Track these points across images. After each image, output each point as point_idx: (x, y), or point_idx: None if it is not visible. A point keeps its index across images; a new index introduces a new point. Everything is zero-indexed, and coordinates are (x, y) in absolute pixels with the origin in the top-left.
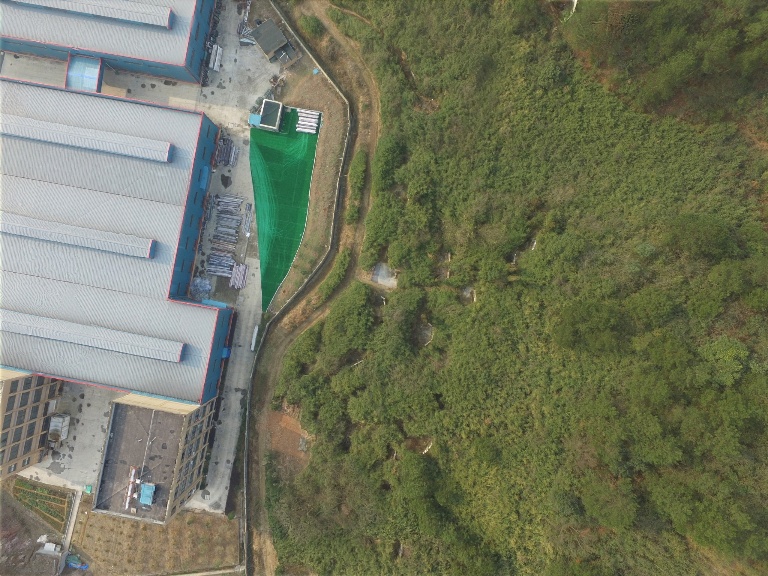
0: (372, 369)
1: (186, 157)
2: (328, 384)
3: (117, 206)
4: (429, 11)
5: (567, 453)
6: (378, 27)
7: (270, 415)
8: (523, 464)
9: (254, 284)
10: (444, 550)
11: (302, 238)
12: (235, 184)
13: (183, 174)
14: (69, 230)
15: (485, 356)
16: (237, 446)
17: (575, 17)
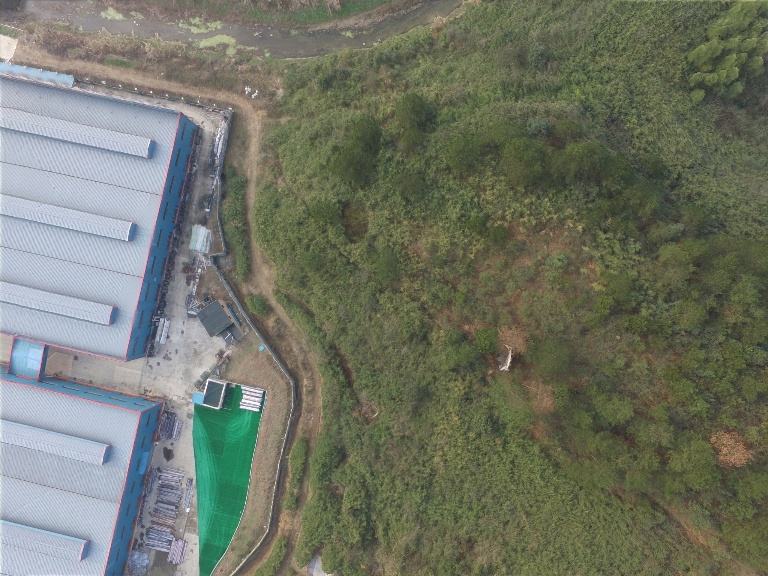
0: None
1: (122, 457)
2: None
3: (53, 500)
4: (369, 326)
5: None
6: (321, 326)
7: None
8: None
9: (192, 560)
10: None
11: (241, 517)
12: (177, 458)
13: (119, 473)
14: (3, 530)
15: None
16: None
17: (508, 375)
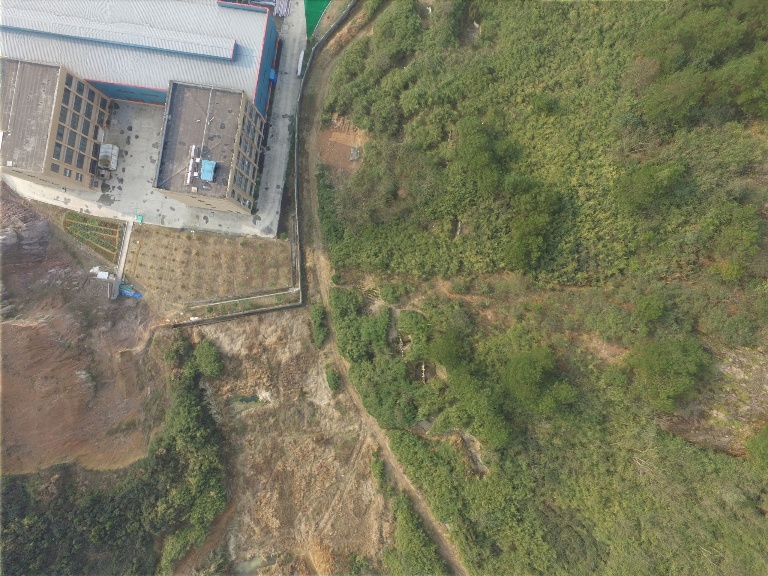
0: (423, 62)
1: None
2: (378, 86)
3: None
4: None
5: (625, 88)
6: None
7: (319, 135)
8: (581, 107)
9: (298, 12)
10: (504, 210)
11: None
12: None
13: None
14: None
15: (537, 27)
16: (287, 170)
17: None
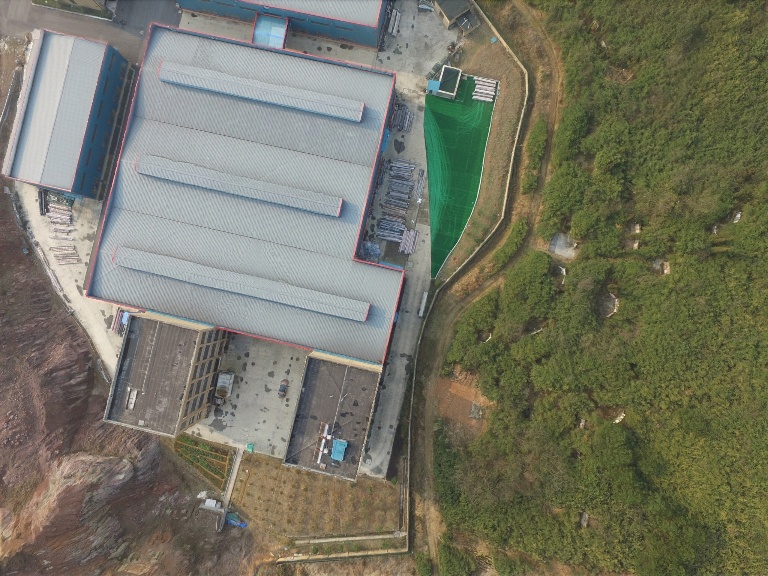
0: (558, 337)
1: (377, 118)
2: (508, 351)
3: (304, 164)
4: None
5: None
6: None
7: (438, 382)
8: (735, 436)
9: (424, 250)
10: (640, 521)
11: (474, 206)
12: (408, 150)
13: (373, 135)
14: (260, 185)
15: (685, 327)
16: (401, 411)
17: None
